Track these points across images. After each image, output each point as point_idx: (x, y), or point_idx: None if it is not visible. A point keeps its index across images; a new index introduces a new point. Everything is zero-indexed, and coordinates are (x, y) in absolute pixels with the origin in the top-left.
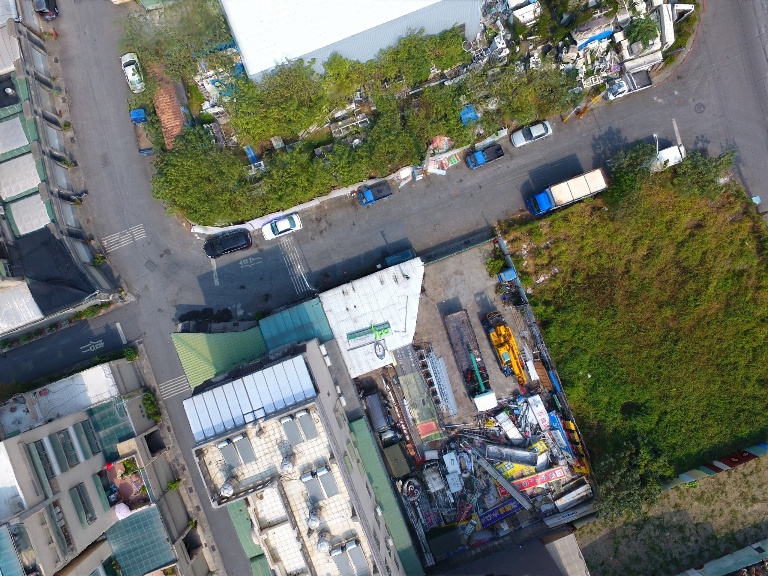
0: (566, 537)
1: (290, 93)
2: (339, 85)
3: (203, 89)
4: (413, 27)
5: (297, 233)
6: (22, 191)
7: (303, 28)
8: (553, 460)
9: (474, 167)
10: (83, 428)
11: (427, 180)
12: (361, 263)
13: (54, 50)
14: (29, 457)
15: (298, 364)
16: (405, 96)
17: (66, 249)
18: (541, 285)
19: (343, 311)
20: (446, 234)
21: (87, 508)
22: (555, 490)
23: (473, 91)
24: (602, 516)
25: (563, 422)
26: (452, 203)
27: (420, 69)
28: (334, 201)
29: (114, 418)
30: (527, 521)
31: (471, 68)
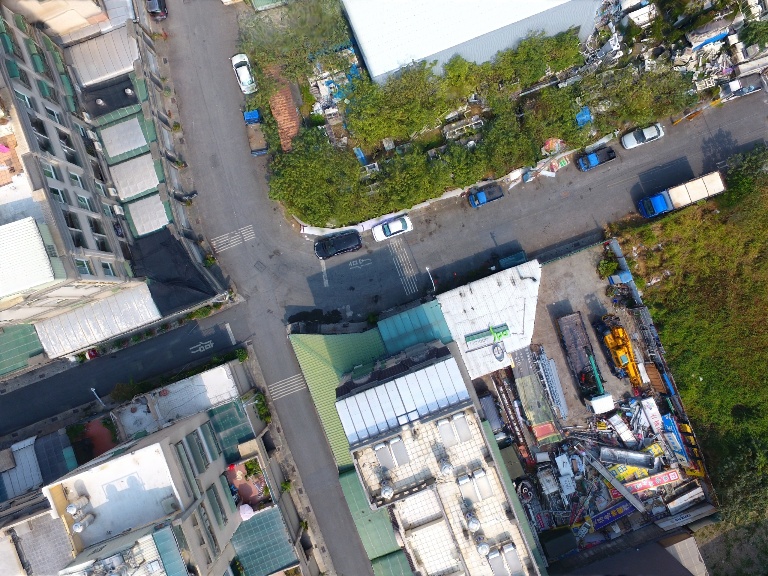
0: (686, 540)
1: (413, 95)
2: (459, 87)
3: (314, 90)
4: (535, 29)
5: (406, 235)
6: (140, 192)
7: (426, 30)
8: (665, 463)
9: (586, 169)
10: (209, 429)
11: (537, 182)
12: (471, 265)
13: (163, 51)
14: (179, 458)
15: (451, 366)
16: (516, 98)
17: (185, 250)
18: (652, 288)
19: (461, 313)
20: (556, 236)
21: (220, 509)
22: (667, 493)
23: (587, 93)
24: (719, 519)
25: (679, 425)
26: (562, 205)
27: (537, 71)
28: (443, 203)
29: (234, 419)
30: (638, 524)
31: (583, 70)
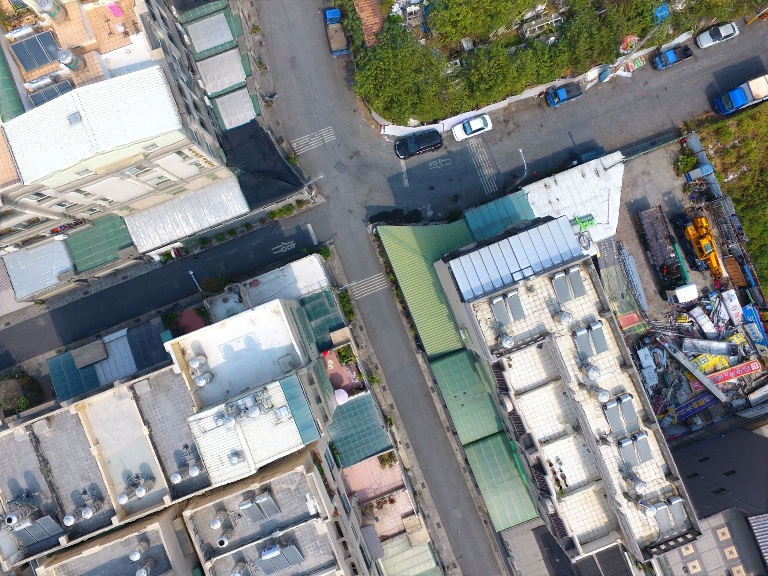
0: None
1: None
2: None
3: None
4: None
5: (486, 135)
6: (227, 86)
7: None
8: (745, 355)
9: (663, 67)
10: (305, 312)
11: (613, 82)
12: (549, 164)
13: None
14: None
15: (563, 224)
16: None
17: (273, 143)
18: (729, 183)
19: (546, 204)
20: (632, 135)
21: None
22: (747, 385)
23: None
24: None
25: (760, 314)
26: (638, 105)
27: None
28: (521, 103)
29: (324, 309)
30: (719, 416)
31: None
